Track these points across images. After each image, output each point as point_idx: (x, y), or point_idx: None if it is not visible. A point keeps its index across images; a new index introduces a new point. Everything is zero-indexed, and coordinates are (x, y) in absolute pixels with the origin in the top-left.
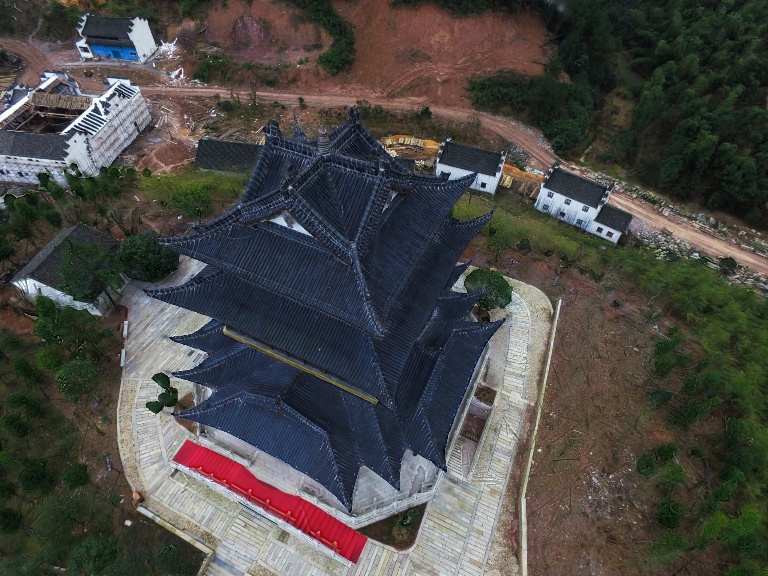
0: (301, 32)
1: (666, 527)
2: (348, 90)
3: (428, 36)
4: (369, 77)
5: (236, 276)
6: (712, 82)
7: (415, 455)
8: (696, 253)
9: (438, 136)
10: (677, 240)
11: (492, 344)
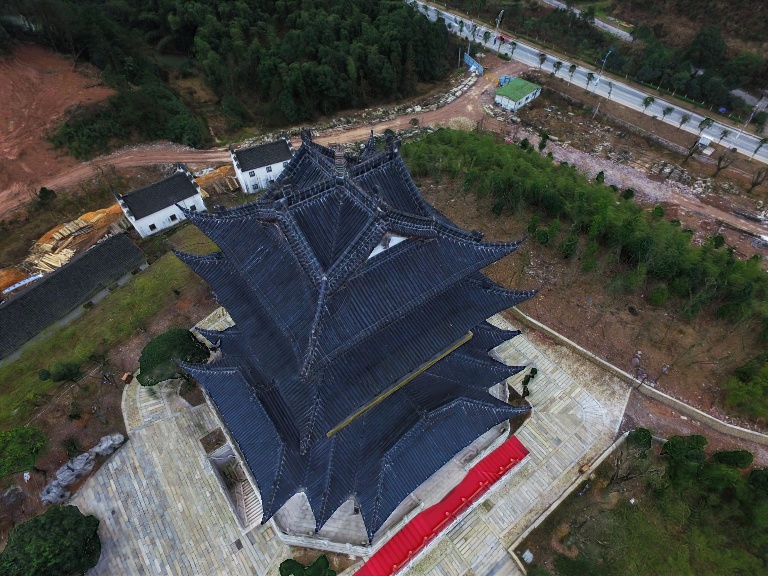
0: None
1: (570, 257)
2: None
3: None
4: None
5: None
6: (242, 29)
7: None
8: (361, 144)
9: (85, 206)
10: (343, 145)
11: None
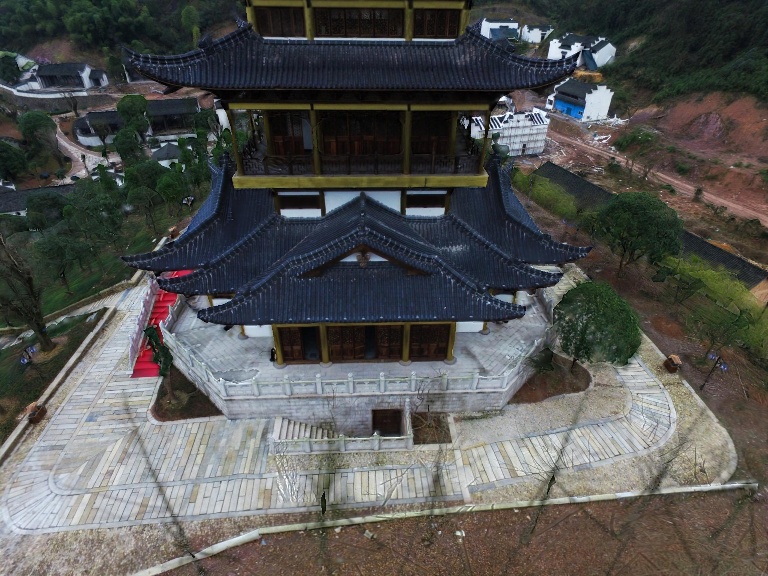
0: None
1: None
2: None
3: None
4: None
5: None
6: None
7: (271, 360)
8: None
9: None
10: None
11: (534, 408)
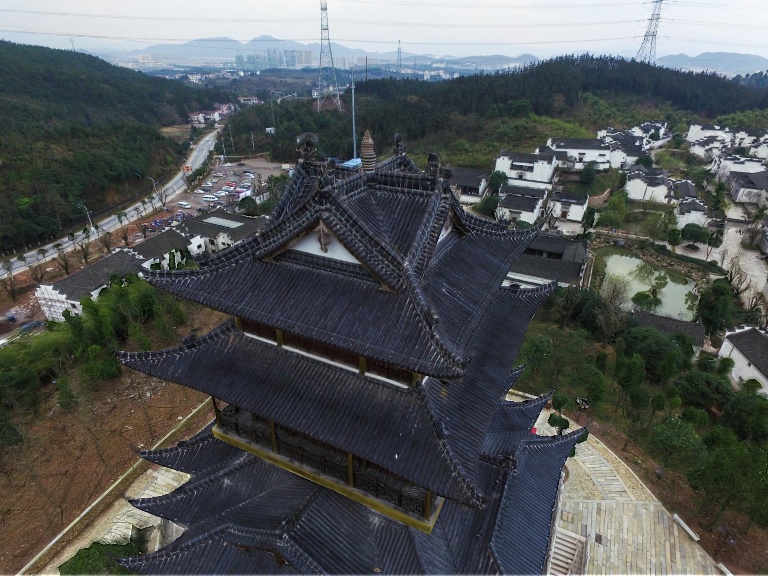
0: None
1: None
2: None
3: None
4: None
5: None
6: None
7: None
8: None
9: None
10: None
11: None
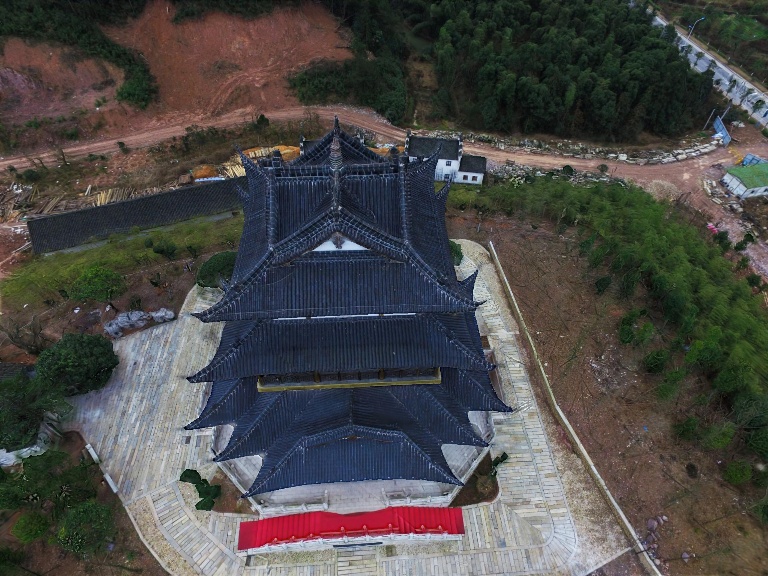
0: (82, 71)
1: (655, 373)
2: (166, 120)
3: (226, 45)
4: (183, 101)
5: (271, 324)
6: (487, 31)
7: None
8: (538, 171)
9: (284, 140)
10: (520, 166)
11: None
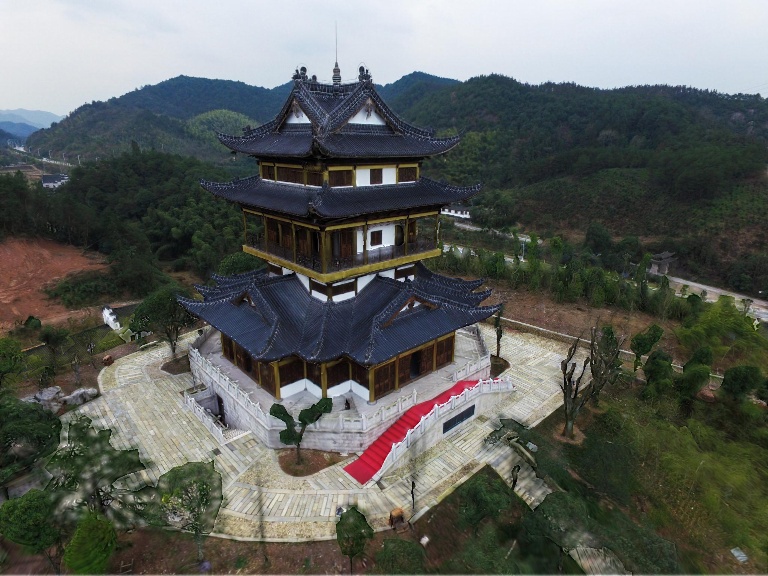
0: None
1: None
2: None
3: None
4: None
5: None
6: None
7: None
8: None
9: None
10: None
11: None
